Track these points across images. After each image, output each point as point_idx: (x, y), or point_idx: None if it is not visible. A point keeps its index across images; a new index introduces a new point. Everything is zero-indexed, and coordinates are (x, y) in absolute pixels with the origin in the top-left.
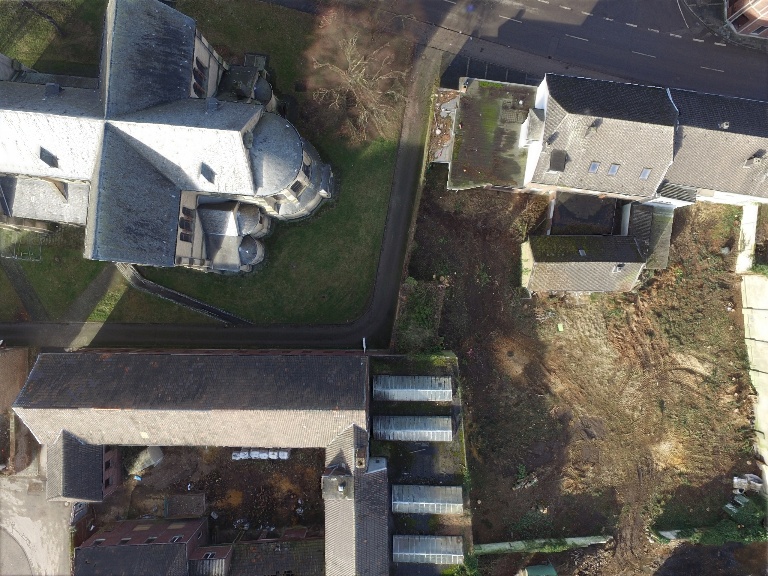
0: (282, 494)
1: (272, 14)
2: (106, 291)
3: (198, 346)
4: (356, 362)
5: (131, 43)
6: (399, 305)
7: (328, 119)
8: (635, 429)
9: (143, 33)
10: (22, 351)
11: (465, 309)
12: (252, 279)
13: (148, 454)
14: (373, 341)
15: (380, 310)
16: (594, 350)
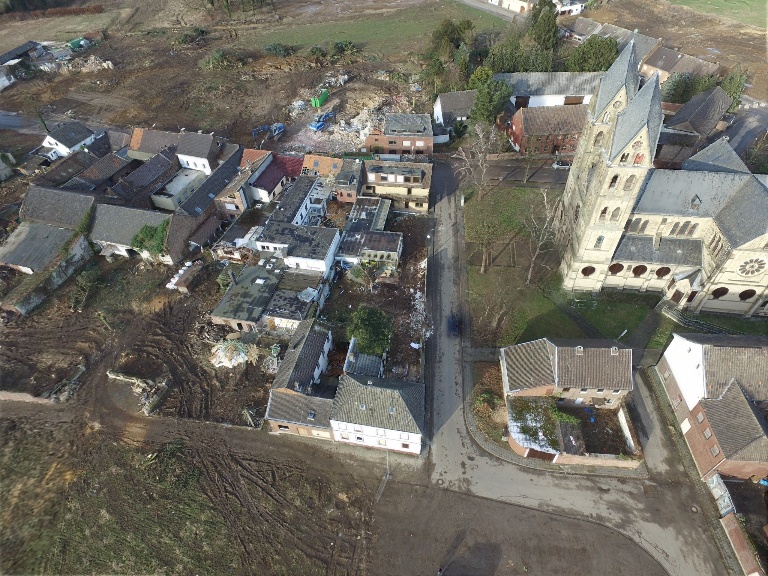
0: None
1: None
2: (655, 329)
3: None
4: None
5: None
6: None
7: None
8: None
9: None
10: None
11: None
12: None
13: None
14: None
15: None
16: None
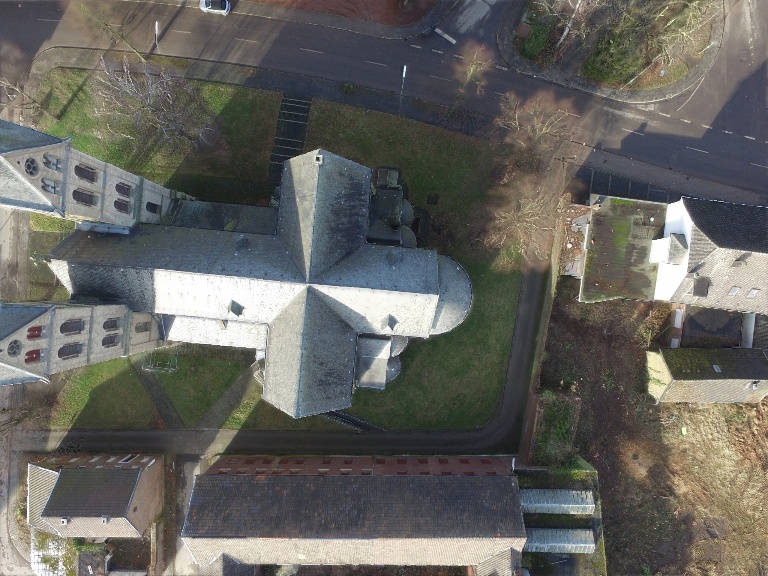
0: None
1: (402, 127)
2: (241, 399)
3: (331, 452)
4: (507, 483)
5: (327, 205)
6: (537, 418)
7: (459, 231)
8: (756, 529)
9: (335, 193)
10: (160, 460)
11: (591, 414)
12: (385, 387)
13: None
14: (502, 446)
15: (509, 416)
16: (716, 453)
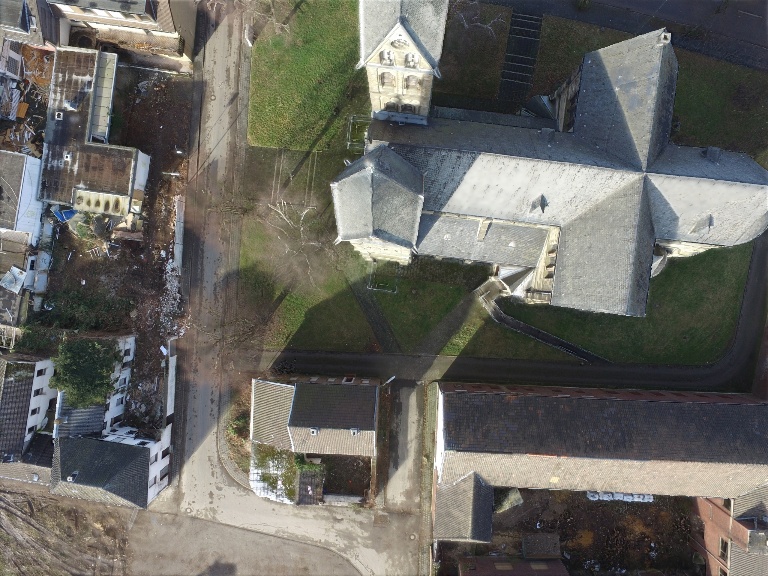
0: (634, 536)
1: None
2: (461, 325)
3: (553, 383)
4: None
5: (661, 92)
6: None
7: None
8: None
9: (664, 81)
10: None
11: None
12: (613, 317)
13: (518, 493)
14: (734, 384)
15: (742, 352)
16: None
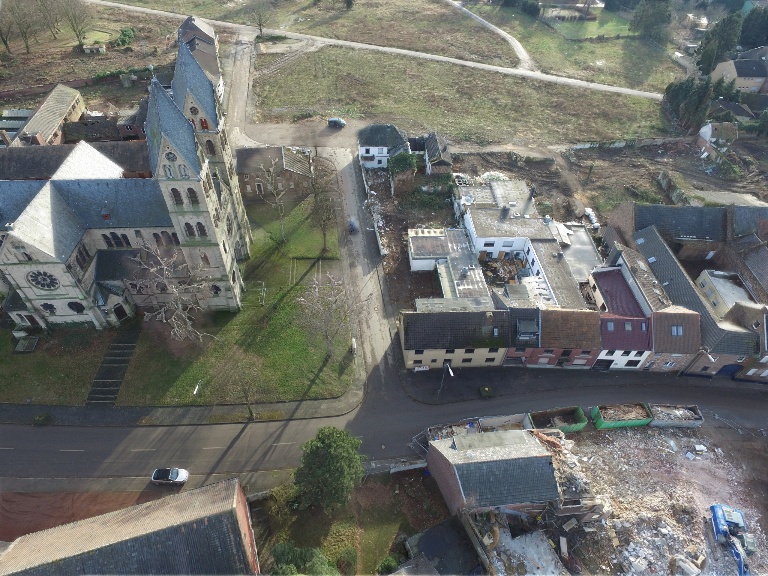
0: None
1: None
2: None
3: None
4: None
5: None
6: None
7: None
8: None
9: None
10: None
11: None
12: None
13: None
14: None
15: None
16: None
